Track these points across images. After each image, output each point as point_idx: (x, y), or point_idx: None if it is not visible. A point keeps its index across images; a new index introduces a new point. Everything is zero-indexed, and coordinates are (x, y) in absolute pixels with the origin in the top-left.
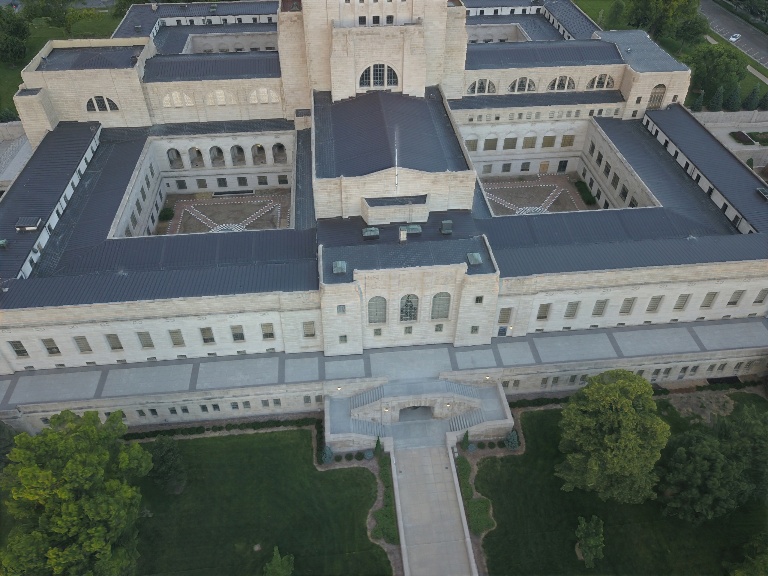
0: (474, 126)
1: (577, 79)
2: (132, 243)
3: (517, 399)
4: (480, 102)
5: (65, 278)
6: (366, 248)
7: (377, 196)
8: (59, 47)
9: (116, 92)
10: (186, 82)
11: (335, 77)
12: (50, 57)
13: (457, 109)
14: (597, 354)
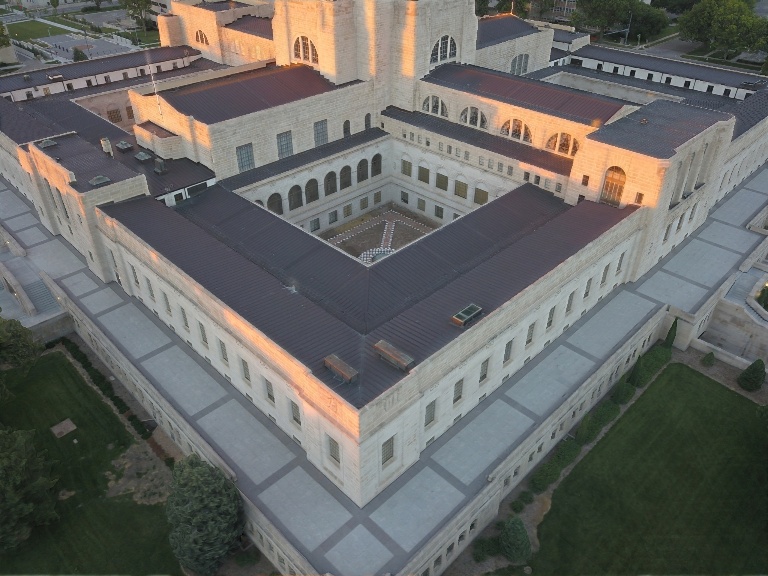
0: (406, 144)
1: (534, 130)
2: (72, 106)
3: (77, 342)
4: (425, 121)
5: (5, 101)
6: (89, 147)
7: (156, 123)
8: None
9: (207, 29)
10: (241, 33)
11: (276, 41)
12: (216, 3)
13: (395, 118)
14: (131, 345)
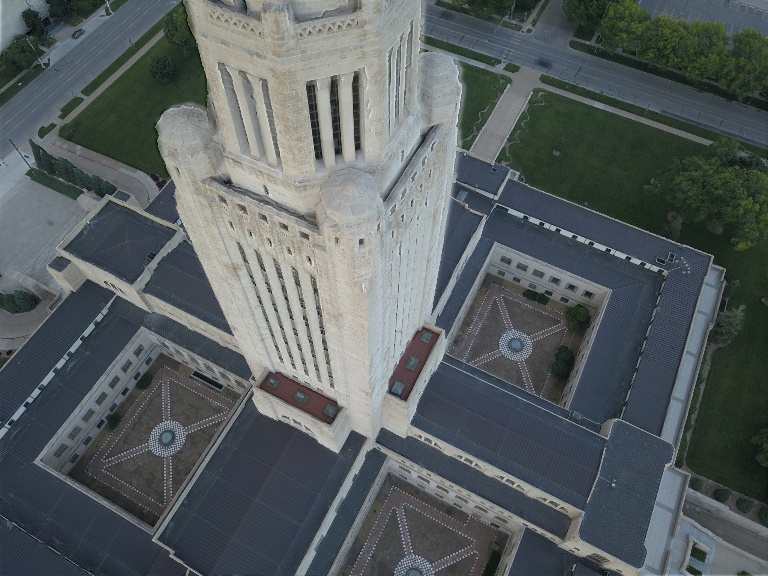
0: None
1: (527, 489)
2: (46, 477)
3: None
4: (420, 451)
5: None
6: None
7: None
8: (114, 201)
9: None
10: (174, 308)
11: (258, 406)
12: (100, 213)
13: (391, 450)
14: None
